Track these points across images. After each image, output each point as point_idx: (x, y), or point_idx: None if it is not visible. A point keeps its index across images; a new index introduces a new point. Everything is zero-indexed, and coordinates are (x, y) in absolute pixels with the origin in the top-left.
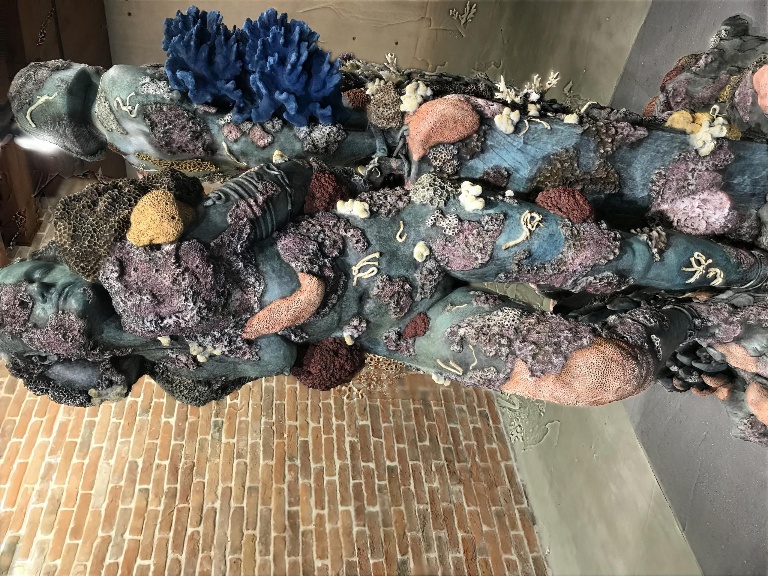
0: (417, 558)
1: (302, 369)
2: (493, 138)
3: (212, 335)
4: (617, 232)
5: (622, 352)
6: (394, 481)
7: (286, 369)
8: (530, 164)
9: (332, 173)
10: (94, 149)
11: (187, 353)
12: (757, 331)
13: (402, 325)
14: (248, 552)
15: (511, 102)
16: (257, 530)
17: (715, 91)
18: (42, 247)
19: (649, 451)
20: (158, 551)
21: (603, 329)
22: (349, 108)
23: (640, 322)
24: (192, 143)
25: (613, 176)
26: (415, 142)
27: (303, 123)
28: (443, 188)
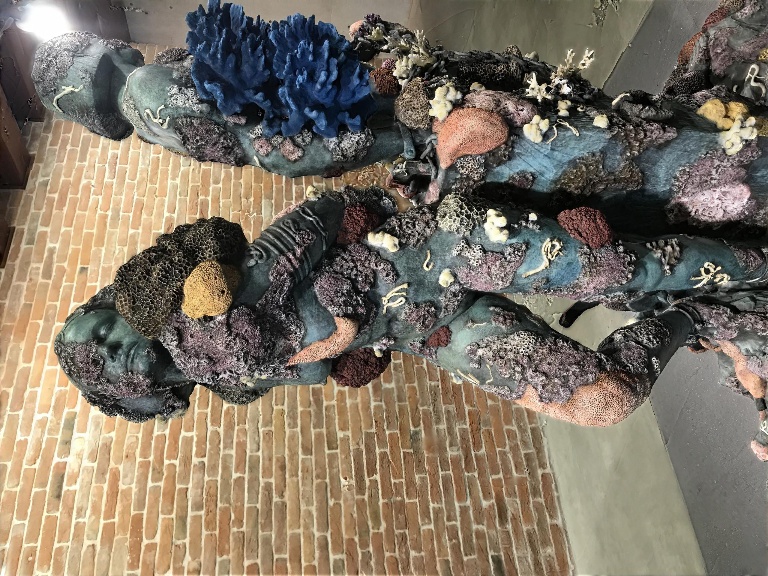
0: (428, 429)
1: (336, 373)
2: (521, 146)
3: (259, 369)
4: (633, 255)
5: (623, 386)
6: (408, 360)
7: (323, 380)
8: (556, 168)
9: (363, 204)
10: (122, 132)
11: (237, 378)
12: (752, 337)
13: (426, 335)
14: (278, 425)
15: (541, 99)
16: (285, 405)
17: (758, 47)
18: (100, 291)
19: None
20: (199, 424)
21: (608, 359)
22: (376, 94)
23: (644, 345)
24: (224, 157)
25: (637, 175)
26: (443, 153)
27: (332, 135)
28: (469, 216)
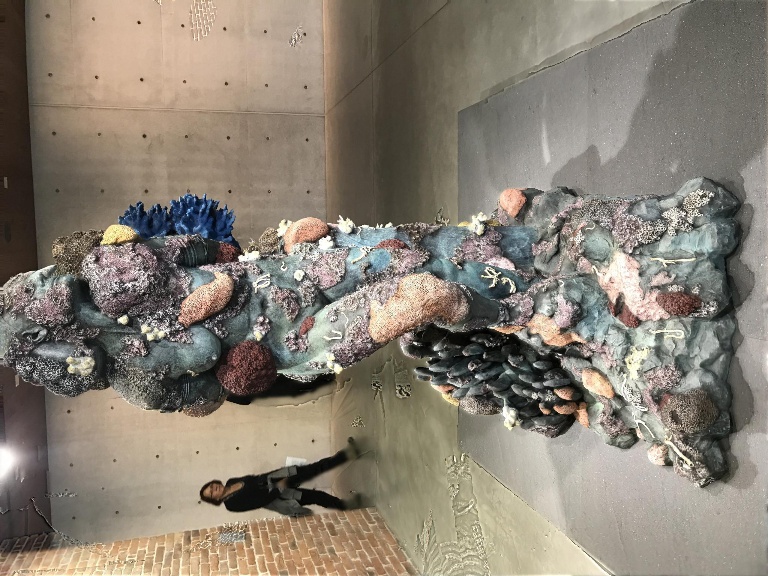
0: None
1: (227, 366)
2: (340, 238)
3: (157, 315)
4: (426, 252)
5: None
6: None
7: (214, 355)
8: None
9: None
10: None
11: (139, 338)
12: (542, 297)
13: (297, 328)
14: None
15: None
16: None
17: None
18: None
19: (583, 542)
20: None
21: None
22: None
23: None
24: None
25: None
26: (289, 245)
27: None
28: None
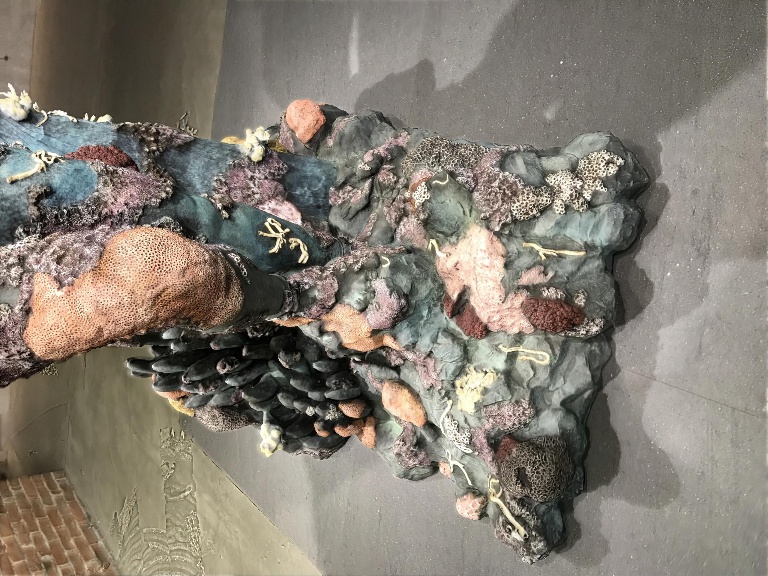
0: None
1: None
2: (0, 125)
3: None
4: None
5: None
6: None
7: None
8: None
9: None
10: None
11: None
12: (353, 279)
13: None
14: None
15: None
16: None
17: None
18: None
19: None
20: None
21: None
22: None
23: None
24: None
25: None
26: None
27: None
28: None
